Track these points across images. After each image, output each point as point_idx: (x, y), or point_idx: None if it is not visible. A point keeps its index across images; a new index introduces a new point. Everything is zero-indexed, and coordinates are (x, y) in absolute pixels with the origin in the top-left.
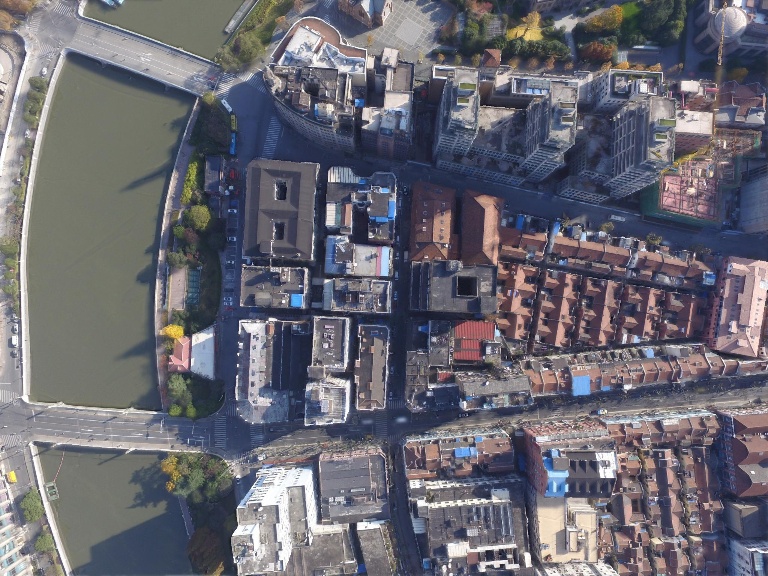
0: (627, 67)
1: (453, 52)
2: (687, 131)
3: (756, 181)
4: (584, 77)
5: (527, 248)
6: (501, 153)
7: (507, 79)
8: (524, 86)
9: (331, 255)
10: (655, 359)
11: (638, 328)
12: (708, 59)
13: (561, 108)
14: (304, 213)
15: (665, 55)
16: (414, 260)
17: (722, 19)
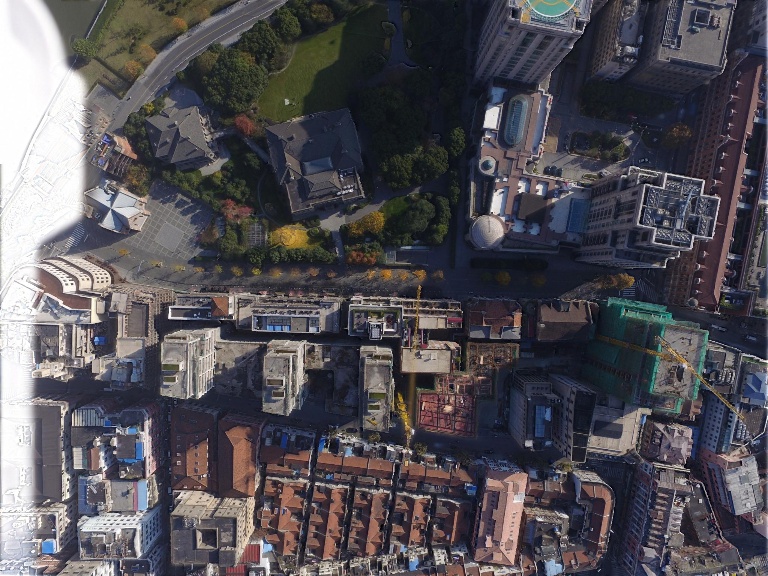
0: (389, 276)
1: (211, 263)
2: (425, 371)
3: (516, 391)
4: (329, 307)
5: (292, 467)
6: (248, 388)
7: (251, 311)
8: (264, 323)
9: (83, 496)
10: (416, 572)
11: (405, 537)
12: (475, 259)
13: (269, 385)
14: (50, 459)
15: (436, 251)
16: (175, 489)
17: (477, 231)
